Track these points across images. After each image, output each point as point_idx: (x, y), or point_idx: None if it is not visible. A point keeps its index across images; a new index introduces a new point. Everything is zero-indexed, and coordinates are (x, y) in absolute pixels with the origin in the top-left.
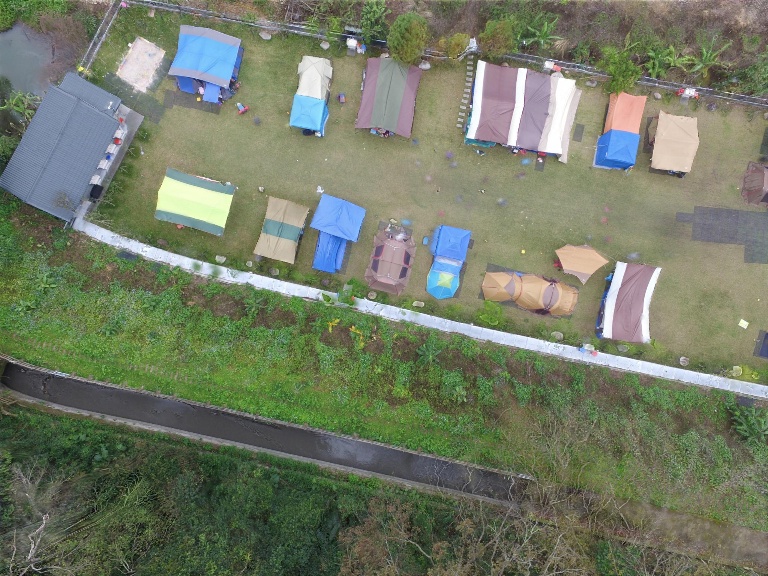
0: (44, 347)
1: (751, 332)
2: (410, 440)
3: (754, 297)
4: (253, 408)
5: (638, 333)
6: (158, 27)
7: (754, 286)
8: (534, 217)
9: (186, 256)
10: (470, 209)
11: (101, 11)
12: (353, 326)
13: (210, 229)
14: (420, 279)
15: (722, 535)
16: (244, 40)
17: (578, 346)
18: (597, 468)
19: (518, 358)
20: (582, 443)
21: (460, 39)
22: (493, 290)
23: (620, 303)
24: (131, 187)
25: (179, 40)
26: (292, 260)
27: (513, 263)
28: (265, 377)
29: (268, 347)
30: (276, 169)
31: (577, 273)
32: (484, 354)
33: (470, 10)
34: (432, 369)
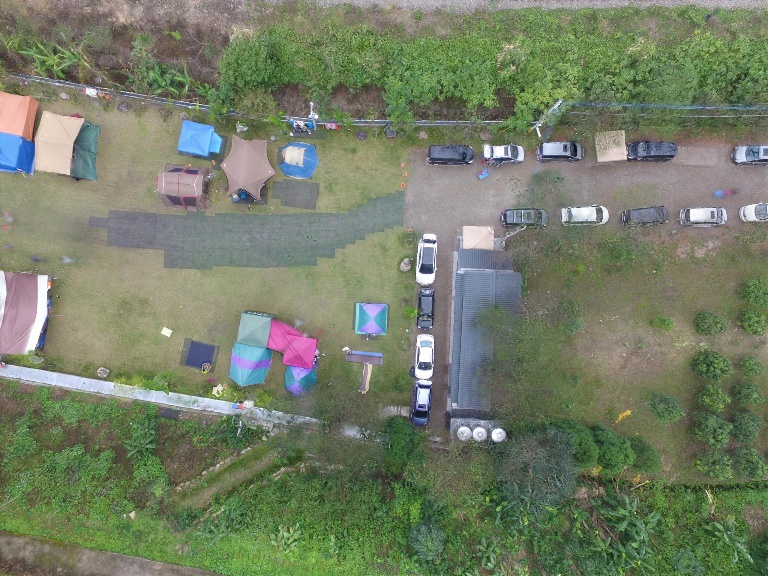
0: None
1: (176, 340)
2: None
3: (176, 304)
4: None
5: (21, 344)
6: None
7: (176, 292)
8: None
9: None
10: None
11: None
12: None
13: None
14: None
15: (63, 558)
16: None
17: None
18: None
19: None
20: None
21: None
22: None
23: (7, 313)
24: None
25: None
26: None
27: None
28: None
29: None
30: None
31: None
32: None
33: None
34: None
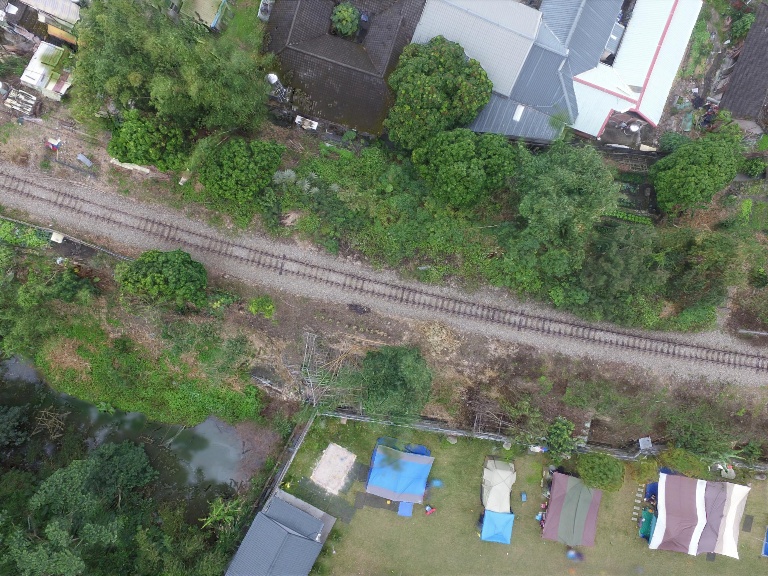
0: None
1: None
2: None
3: None
4: None
5: None
6: (350, 433)
7: None
8: None
9: None
10: None
11: (295, 416)
12: None
13: None
14: None
15: None
16: (431, 442)
17: None
18: None
19: None
20: None
21: (652, 475)
22: None
23: None
24: None
25: (376, 458)
26: None
27: None
28: None
29: None
30: (460, 564)
31: None
32: None
33: (648, 416)
34: None
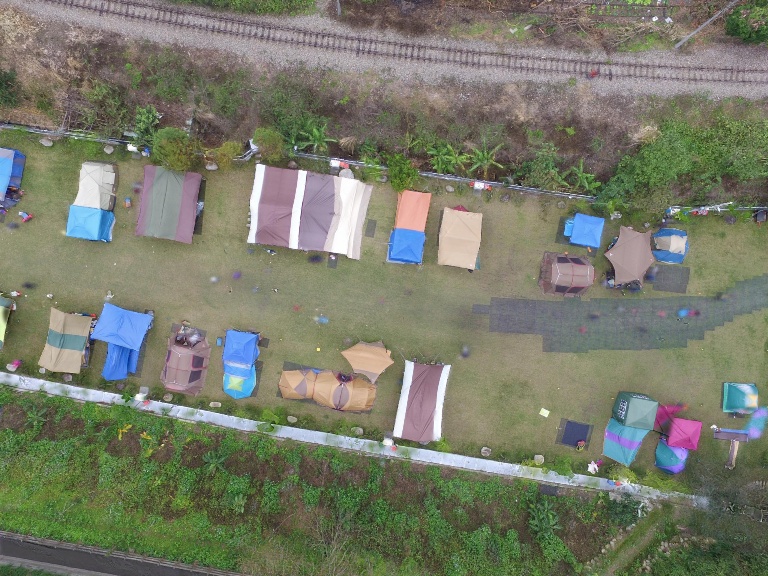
0: None
1: (552, 420)
2: (185, 554)
3: (554, 386)
4: (24, 528)
5: (429, 431)
6: None
7: (553, 375)
8: (329, 314)
9: None
10: (264, 308)
11: None
12: (144, 432)
13: None
14: (217, 379)
15: None
16: (26, 147)
17: (379, 440)
18: (376, 573)
19: (315, 456)
20: (362, 549)
21: (226, 150)
22: (286, 390)
23: (411, 400)
24: None
25: None
26: (77, 370)
27: (310, 360)
28: (37, 496)
29: (46, 463)
30: (65, 275)
31: (366, 372)
32: (280, 454)
33: (252, 111)
34: (218, 476)
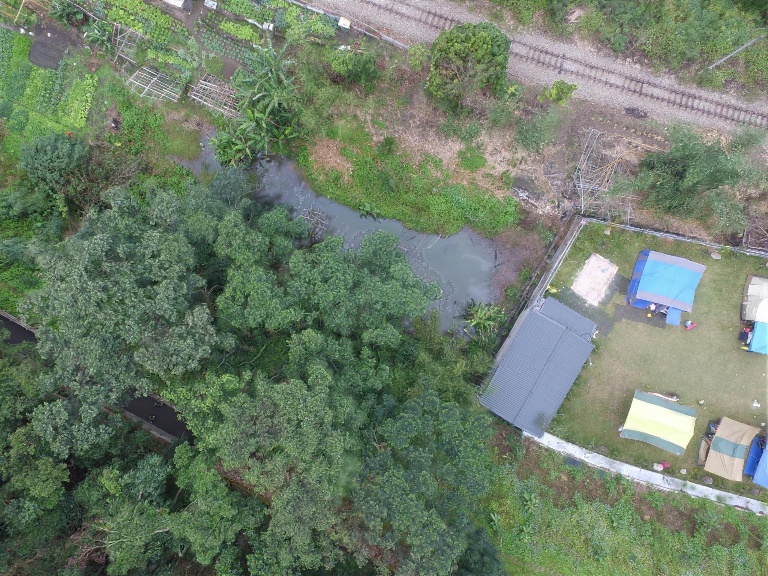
0: (543, 571)
1: None
2: None
3: None
4: None
5: None
6: (614, 244)
7: None
8: None
9: (625, 462)
10: None
11: (557, 226)
12: None
13: (666, 446)
14: None
15: None
16: (693, 258)
17: None
18: None
19: None
20: None
21: None
22: None
23: None
24: (578, 395)
25: (646, 265)
26: (740, 477)
27: None
28: None
29: (734, 570)
30: (715, 382)
31: None
32: None
33: None
34: None
